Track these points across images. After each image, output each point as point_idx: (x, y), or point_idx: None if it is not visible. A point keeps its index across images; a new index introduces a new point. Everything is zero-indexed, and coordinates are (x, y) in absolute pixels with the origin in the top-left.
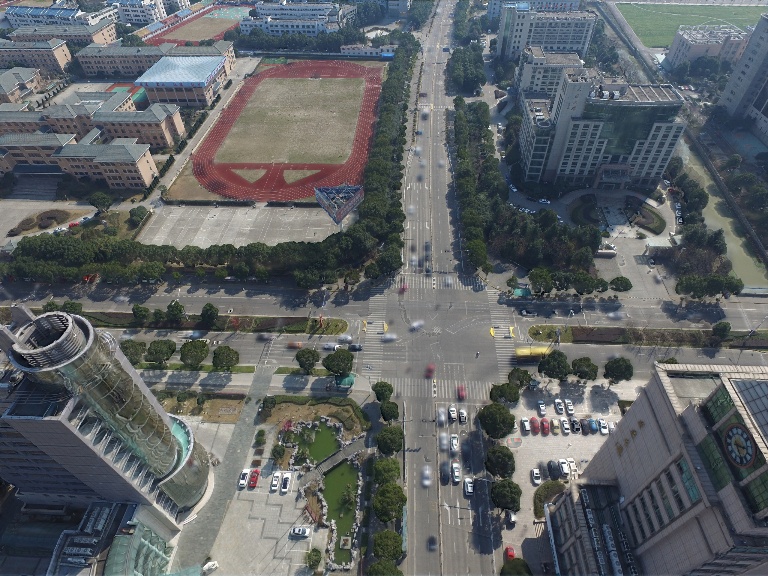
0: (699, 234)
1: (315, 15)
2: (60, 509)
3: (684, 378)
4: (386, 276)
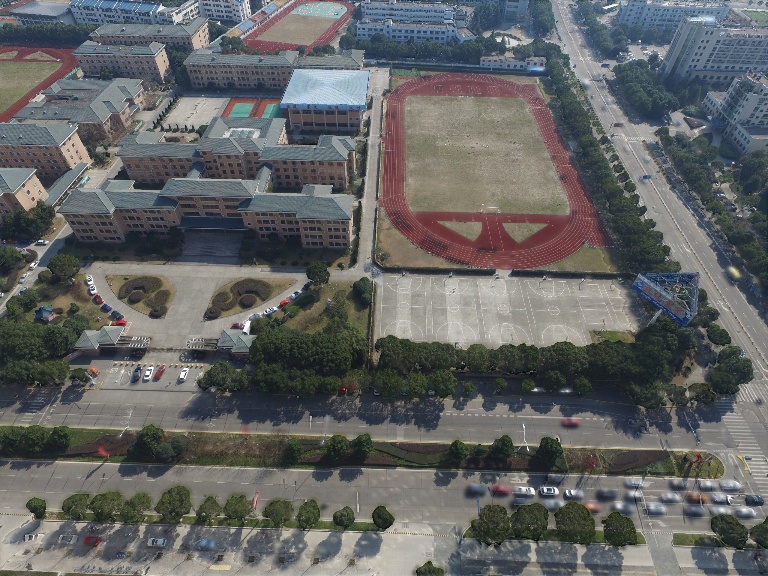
0: None
1: (429, 17)
2: None
3: None
4: None
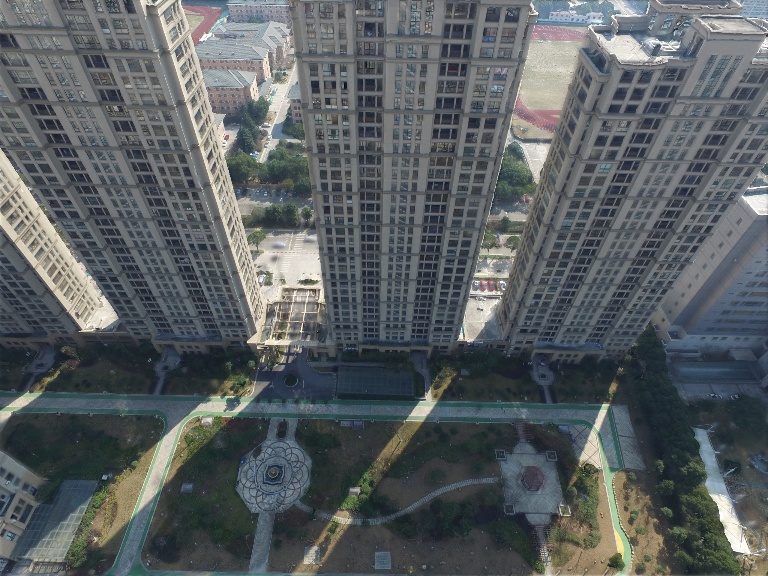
0: None
1: None
2: (696, 352)
3: None
4: None
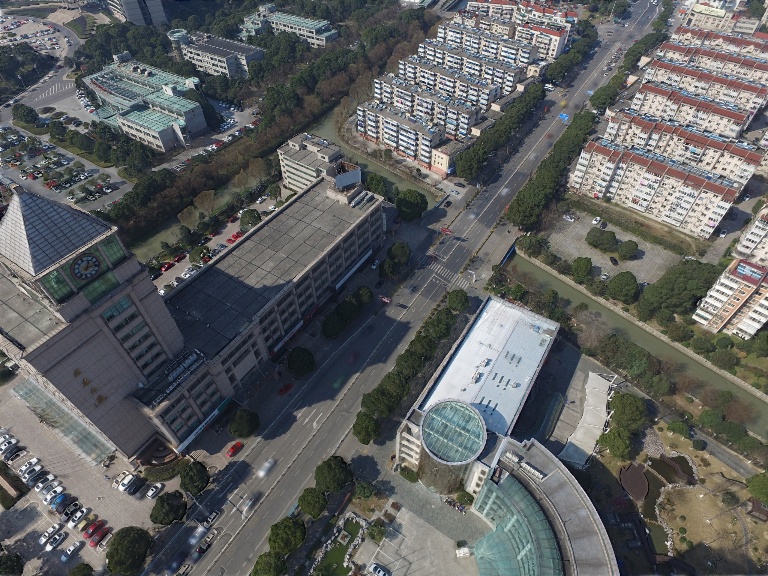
0: None
1: None
2: None
3: (20, 344)
4: None
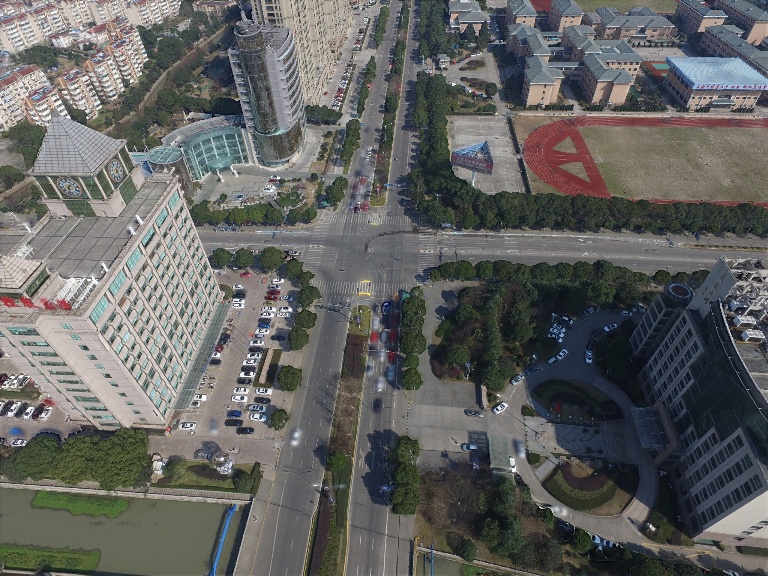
0: (500, 487)
1: None
2: None
3: None
4: (432, 224)
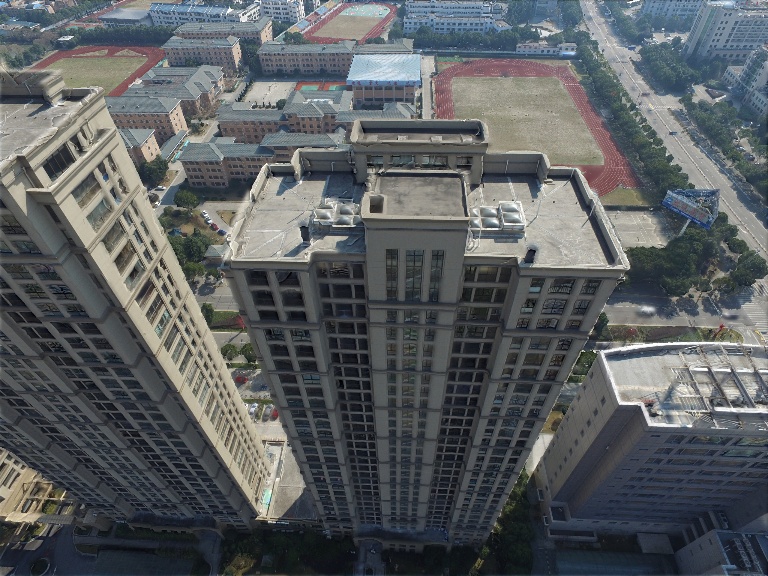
0: None
1: (467, 13)
2: (591, 536)
3: None
4: None
